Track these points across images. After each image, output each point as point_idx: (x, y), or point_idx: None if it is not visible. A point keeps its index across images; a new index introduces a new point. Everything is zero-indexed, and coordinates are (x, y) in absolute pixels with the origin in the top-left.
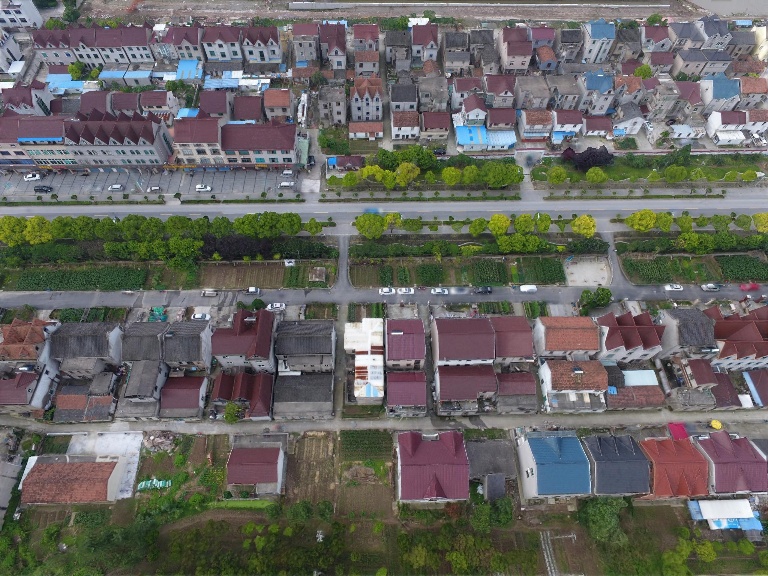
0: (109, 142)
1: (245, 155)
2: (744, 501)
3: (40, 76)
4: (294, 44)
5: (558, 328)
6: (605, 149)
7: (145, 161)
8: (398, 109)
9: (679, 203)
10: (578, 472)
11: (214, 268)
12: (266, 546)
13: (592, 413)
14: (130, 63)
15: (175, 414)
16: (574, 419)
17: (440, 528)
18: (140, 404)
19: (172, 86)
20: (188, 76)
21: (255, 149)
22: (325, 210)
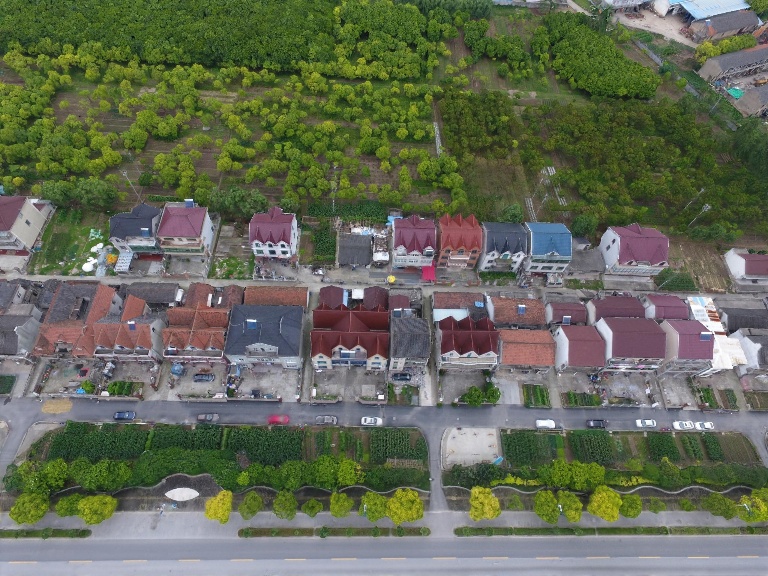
0: None
1: None
2: None
3: None
4: None
5: (542, 344)
6: None
7: None
8: None
9: (310, 573)
10: (538, 230)
11: None
12: None
13: None
14: None
15: None
16: None
17: None
18: None
19: None
20: None
21: None
22: None
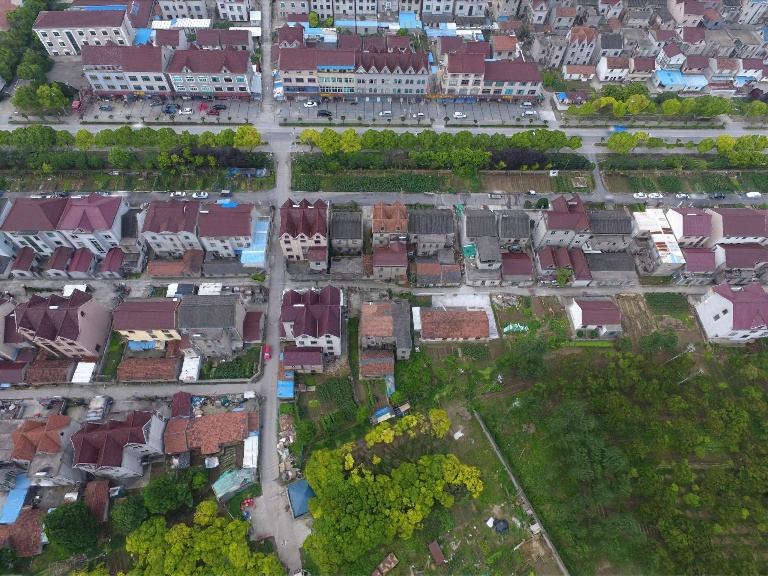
0: (394, 71)
1: (500, 86)
2: None
3: (275, 24)
4: (502, 0)
5: None
6: None
7: (412, 91)
8: (604, 55)
9: None
10: None
11: (491, 177)
12: (632, 365)
13: None
14: (355, 14)
15: (515, 279)
16: None
17: (760, 353)
18: (485, 271)
19: (404, 33)
20: (410, 26)
21: (511, 81)
22: (568, 134)
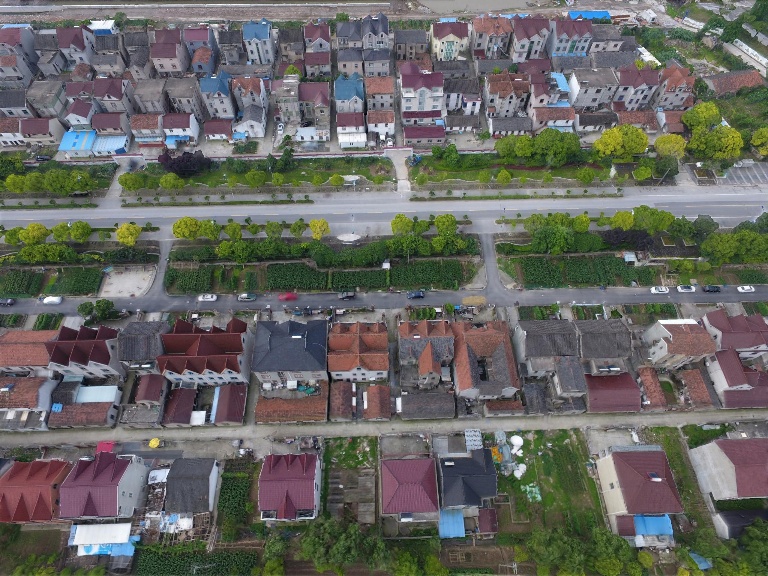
0: None
1: None
2: (125, 525)
3: None
4: None
5: (7, 343)
6: (195, 154)
7: None
8: (13, 115)
9: (262, 209)
10: None
11: None
12: None
13: (38, 431)
14: None
15: None
16: (16, 438)
17: None
18: None
19: None
20: None
21: None
22: None
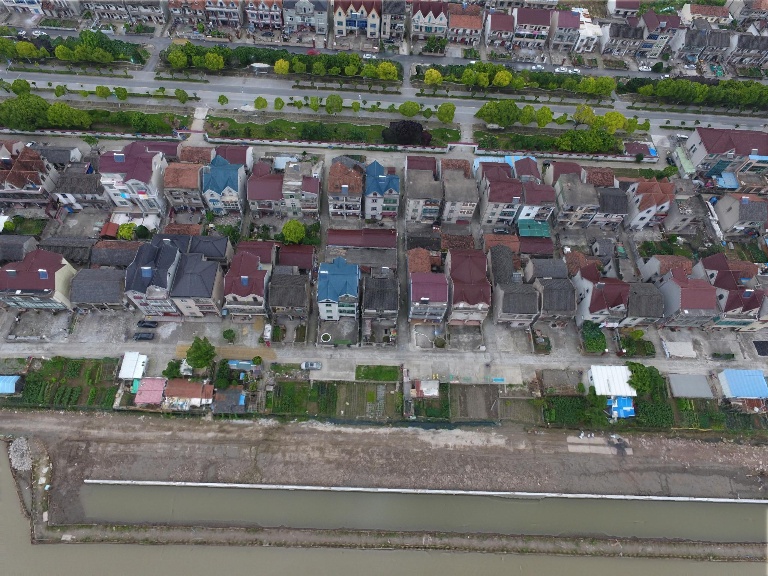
0: None
1: None
2: None
3: None
4: None
5: None
6: (394, 128)
7: None
8: None
9: None
10: None
11: None
12: None
13: None
14: None
15: None
16: None
17: None
18: None
19: None
20: None
21: None
22: (640, 119)
